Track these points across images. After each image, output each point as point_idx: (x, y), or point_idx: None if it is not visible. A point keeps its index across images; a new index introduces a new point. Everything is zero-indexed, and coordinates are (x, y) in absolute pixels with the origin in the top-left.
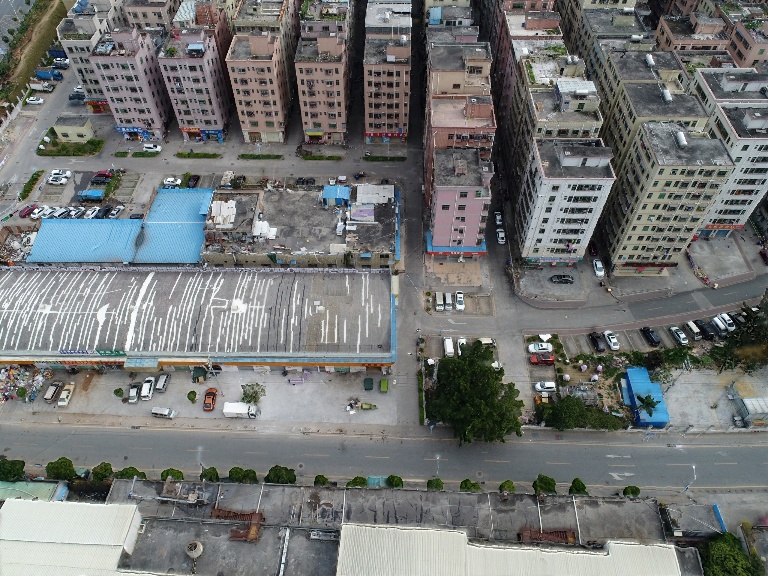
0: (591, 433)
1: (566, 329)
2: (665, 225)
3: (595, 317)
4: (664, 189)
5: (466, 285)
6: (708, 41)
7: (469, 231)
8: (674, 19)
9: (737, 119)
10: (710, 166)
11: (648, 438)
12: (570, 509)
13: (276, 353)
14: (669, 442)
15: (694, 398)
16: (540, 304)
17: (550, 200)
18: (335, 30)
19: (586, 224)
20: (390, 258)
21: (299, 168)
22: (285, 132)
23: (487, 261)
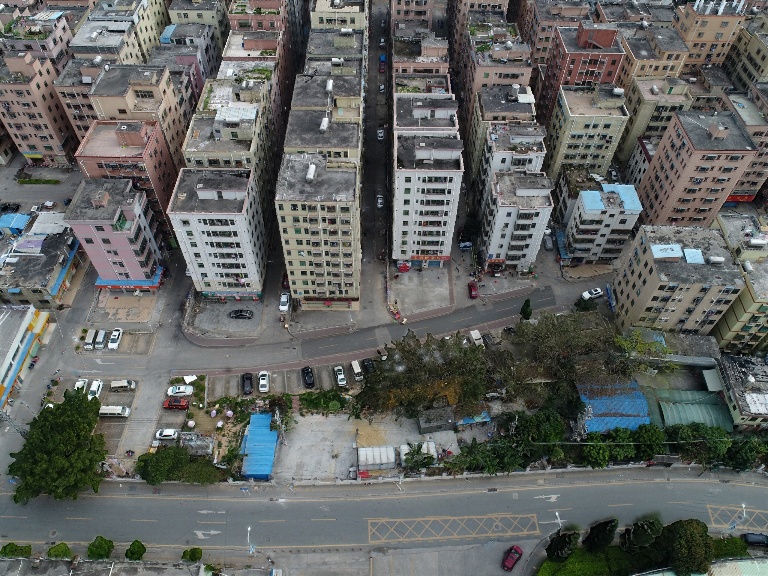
0: (193, 486)
1: (221, 369)
2: (320, 260)
3: (259, 356)
4: (294, 225)
5: (132, 321)
6: (428, 64)
7: (130, 265)
8: (407, 40)
9: (410, 148)
10: (328, 202)
11: (248, 492)
12: None
13: None
14: (272, 496)
15: (319, 446)
16: (204, 342)
17: (189, 234)
18: (39, 49)
19: (243, 258)
20: (44, 293)
21: (10, 193)
22: (12, 154)
23: (166, 295)
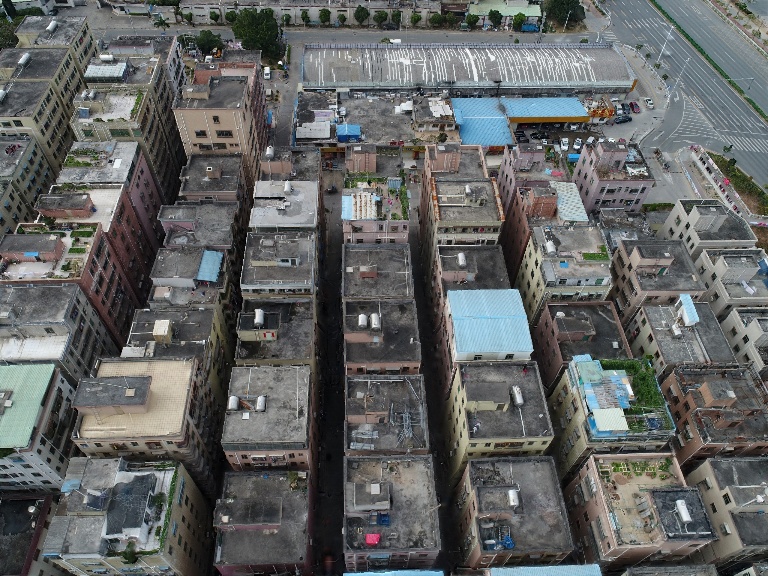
0: None
1: None
2: None
3: None
4: None
5: None
6: None
7: None
8: None
9: None
10: None
11: None
12: (223, 3)
13: (375, 44)
14: None
15: None
16: None
17: None
18: None
19: None
20: None
21: None
22: None
23: None
